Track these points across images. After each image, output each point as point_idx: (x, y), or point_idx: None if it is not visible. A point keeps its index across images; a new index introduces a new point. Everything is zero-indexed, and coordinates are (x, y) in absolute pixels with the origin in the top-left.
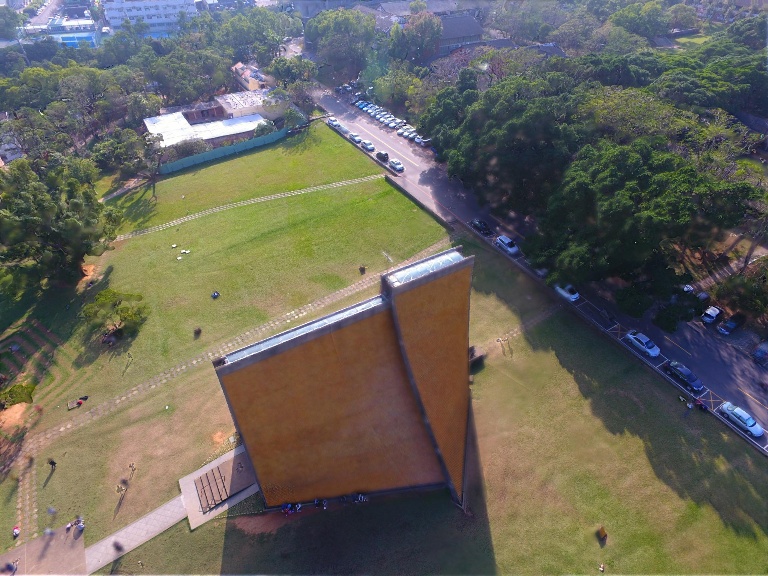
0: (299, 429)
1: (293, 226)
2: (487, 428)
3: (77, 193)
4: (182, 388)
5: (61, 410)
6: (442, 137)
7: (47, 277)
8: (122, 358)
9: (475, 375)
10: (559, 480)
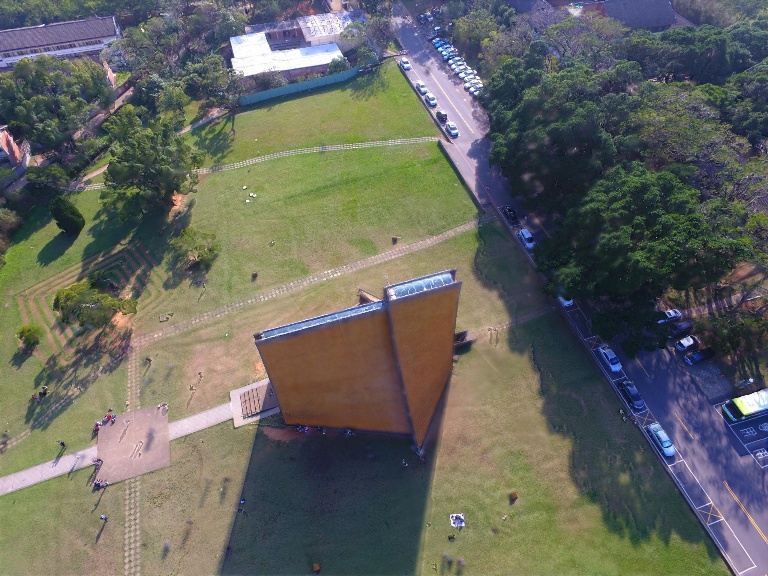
0: (311, 381)
1: (345, 184)
2: (456, 400)
3: (170, 133)
4: (239, 321)
5: (155, 321)
6: (495, 117)
7: (147, 209)
8: (198, 287)
9: (461, 355)
10: (498, 451)
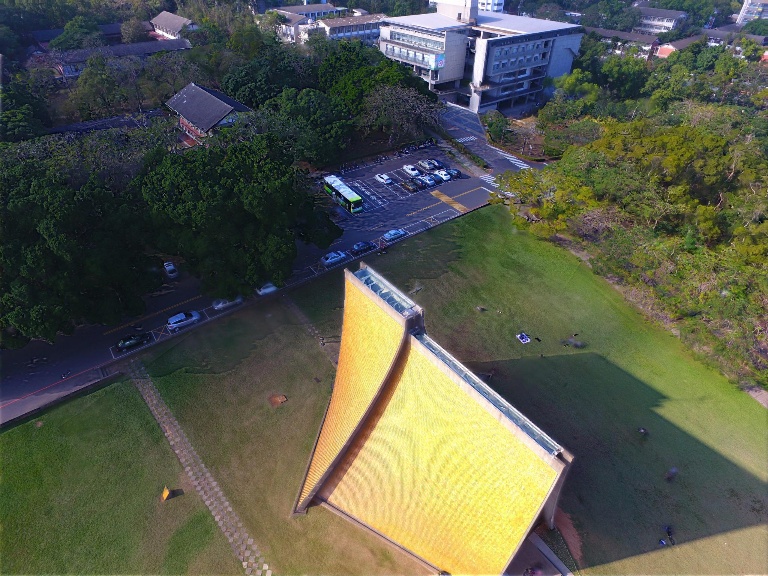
0: None
1: None
2: None
3: None
4: None
5: None
6: None
7: None
8: None
9: None
10: (450, 323)
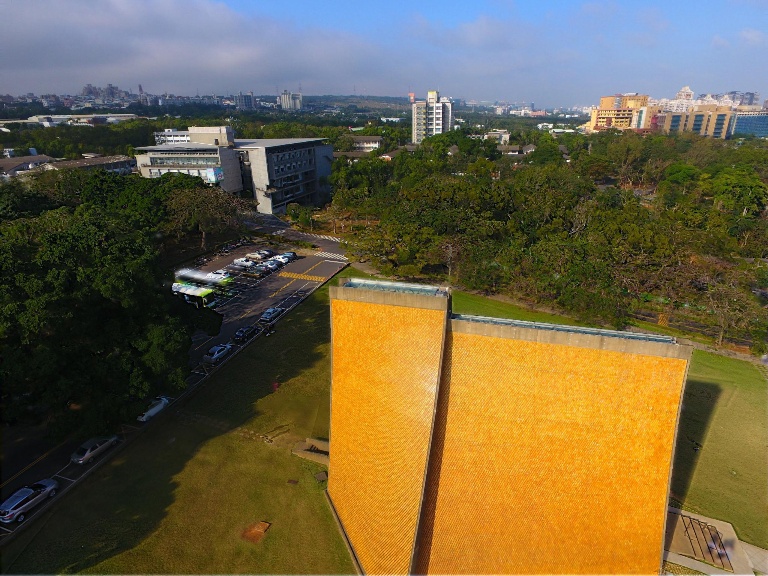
0: None
1: None
2: None
3: None
4: None
5: None
6: None
7: None
8: None
9: None
10: None
